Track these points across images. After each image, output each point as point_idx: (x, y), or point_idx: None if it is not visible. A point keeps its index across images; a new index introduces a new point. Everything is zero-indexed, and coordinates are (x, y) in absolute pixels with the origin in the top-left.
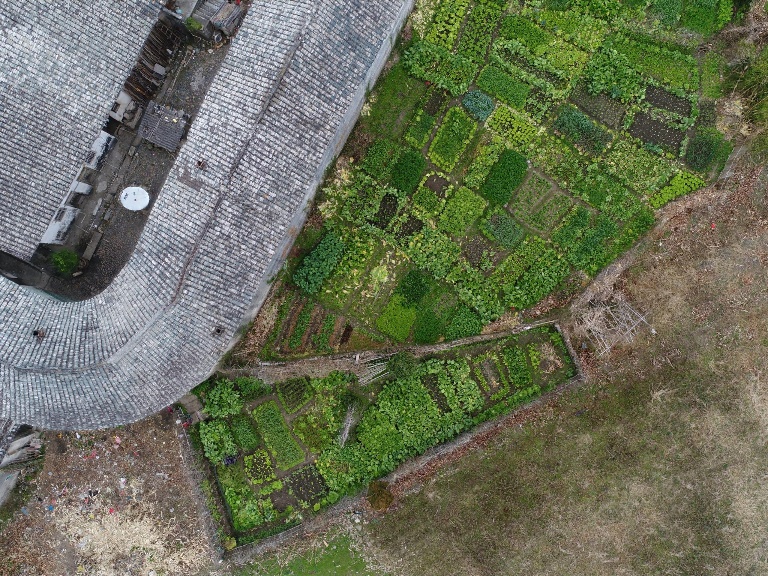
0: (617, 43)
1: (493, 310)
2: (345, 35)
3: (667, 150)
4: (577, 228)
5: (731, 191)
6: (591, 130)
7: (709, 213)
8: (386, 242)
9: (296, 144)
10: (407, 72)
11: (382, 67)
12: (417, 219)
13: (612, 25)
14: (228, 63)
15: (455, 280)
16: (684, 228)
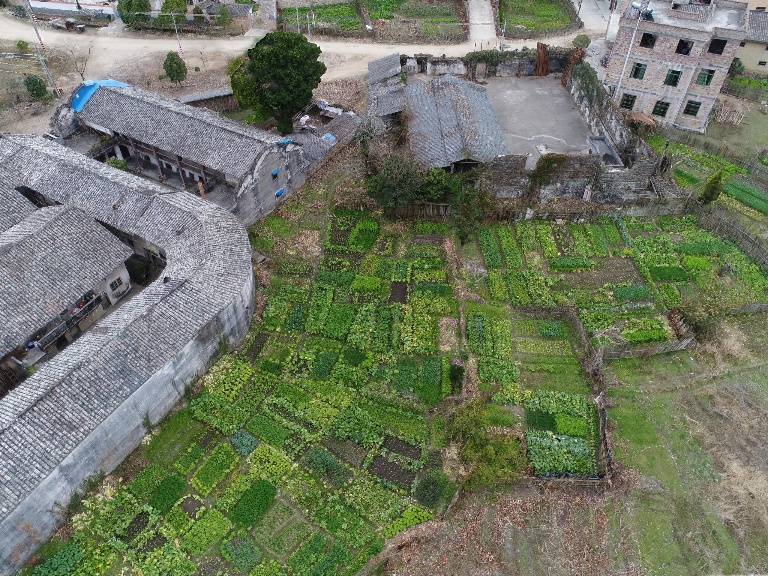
0: (363, 404)
1: None
2: (120, 368)
3: (400, 487)
4: (311, 553)
5: (460, 527)
6: (335, 466)
7: (441, 547)
8: (127, 558)
9: (47, 439)
10: (192, 416)
11: (169, 409)
12: (163, 537)
13: (360, 392)
14: (26, 382)
15: None
16: (417, 560)
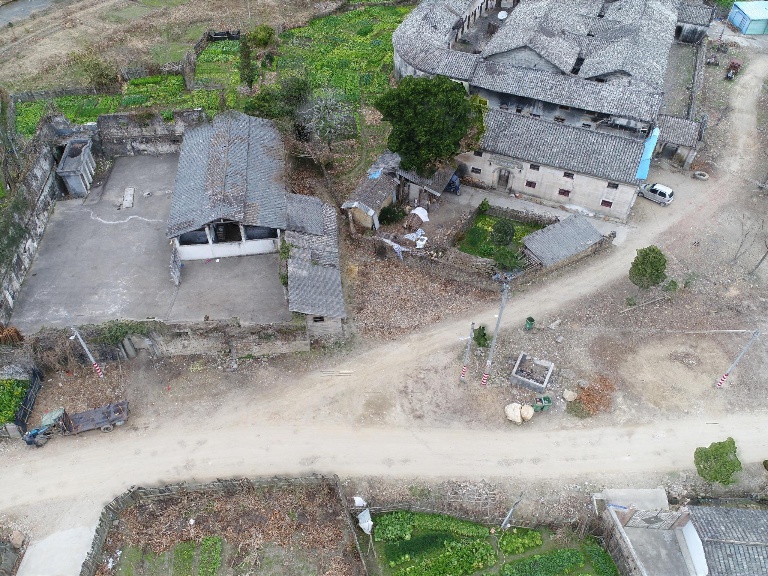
0: None
1: (368, 7)
2: None
3: None
4: None
5: None
6: None
7: None
8: None
9: None
10: None
11: None
12: None
13: None
14: None
15: None
16: None
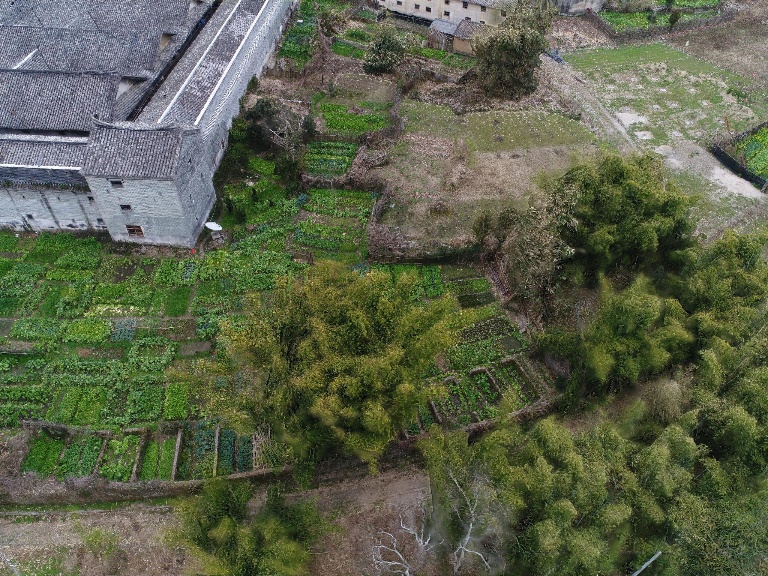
0: None
1: (695, 4)
2: None
3: None
4: None
5: None
6: None
7: (759, 2)
8: None
9: None
10: None
11: None
12: None
13: None
14: None
15: (678, 2)
16: (752, 3)
